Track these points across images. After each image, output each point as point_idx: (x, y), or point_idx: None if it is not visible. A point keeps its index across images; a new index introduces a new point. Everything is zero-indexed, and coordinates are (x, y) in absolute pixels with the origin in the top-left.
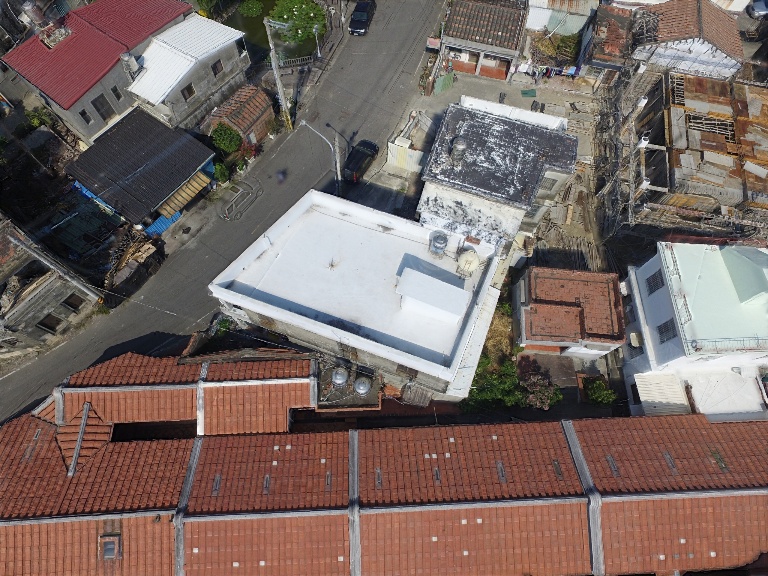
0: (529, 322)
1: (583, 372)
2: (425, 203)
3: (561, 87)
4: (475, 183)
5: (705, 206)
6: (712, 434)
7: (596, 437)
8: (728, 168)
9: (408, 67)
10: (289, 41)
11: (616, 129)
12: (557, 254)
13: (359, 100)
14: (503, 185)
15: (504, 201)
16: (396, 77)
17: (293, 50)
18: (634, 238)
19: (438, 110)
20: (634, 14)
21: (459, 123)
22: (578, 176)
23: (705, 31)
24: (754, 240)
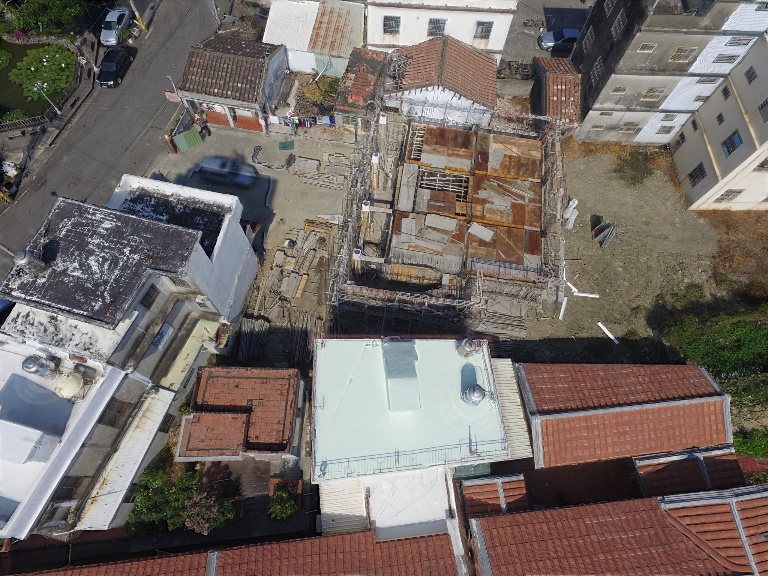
0: (187, 434)
1: (280, 475)
2: (13, 320)
3: (322, 137)
4: (56, 298)
5: (429, 274)
6: (371, 558)
7: (237, 573)
8: (449, 232)
9: (159, 121)
10: (32, 97)
11: (370, 183)
12: (279, 333)
13: (95, 162)
14: (90, 299)
15: (84, 320)
16: (142, 134)
17: (35, 107)
18: (355, 313)
19: (182, 170)
20: (390, 57)
21: (63, 221)
22: (320, 239)
23: (446, 77)
24: (467, 314)
